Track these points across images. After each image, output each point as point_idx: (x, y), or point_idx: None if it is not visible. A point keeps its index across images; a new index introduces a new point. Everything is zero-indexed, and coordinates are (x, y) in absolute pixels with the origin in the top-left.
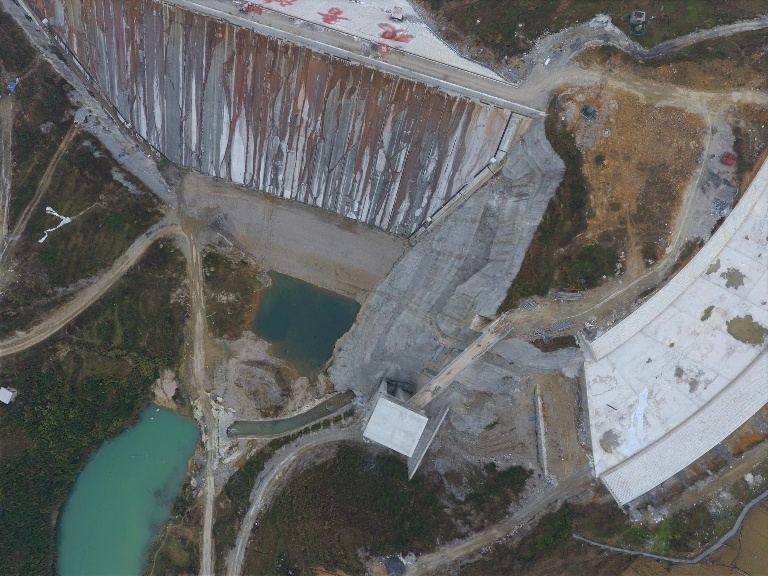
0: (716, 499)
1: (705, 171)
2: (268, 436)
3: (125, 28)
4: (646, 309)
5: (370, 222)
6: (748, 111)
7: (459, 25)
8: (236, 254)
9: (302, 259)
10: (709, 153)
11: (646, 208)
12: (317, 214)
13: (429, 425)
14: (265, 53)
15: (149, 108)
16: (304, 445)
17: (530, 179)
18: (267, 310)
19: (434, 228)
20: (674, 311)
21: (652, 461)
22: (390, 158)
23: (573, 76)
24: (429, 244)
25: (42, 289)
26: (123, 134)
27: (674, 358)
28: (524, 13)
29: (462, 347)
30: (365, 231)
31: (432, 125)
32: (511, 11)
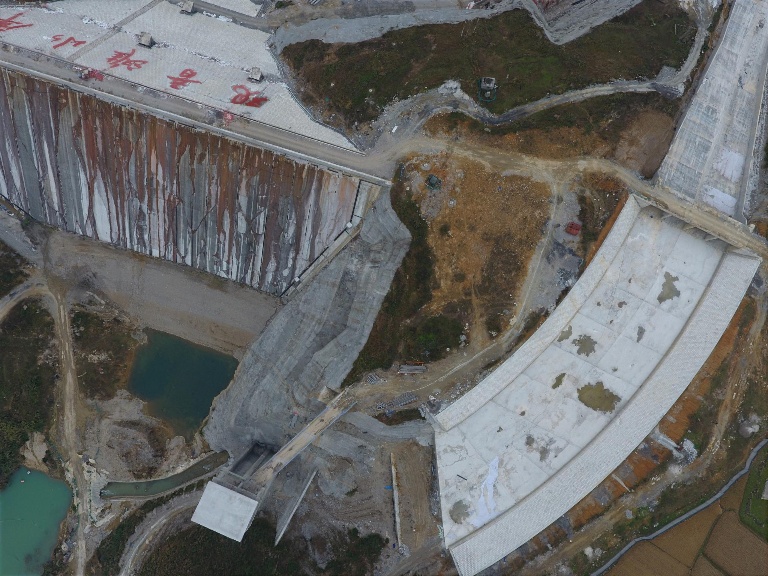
0: (555, 574)
1: (550, 241)
2: (142, 497)
3: None
4: (492, 380)
5: (241, 281)
6: (594, 180)
7: (315, 87)
8: (108, 312)
9: (176, 317)
10: (554, 222)
11: (491, 279)
12: (187, 273)
13: (297, 488)
14: (111, 119)
15: (6, 168)
16: (175, 508)
17: (383, 246)
18: (144, 367)
19: (303, 288)
20: (525, 379)
21: (499, 533)
22: (250, 221)
23: (419, 144)
24: (297, 305)
25: None
26: None
27: (525, 427)
28: (375, 78)
29: (315, 416)
30: (236, 290)
31: (285, 190)
32: (363, 75)
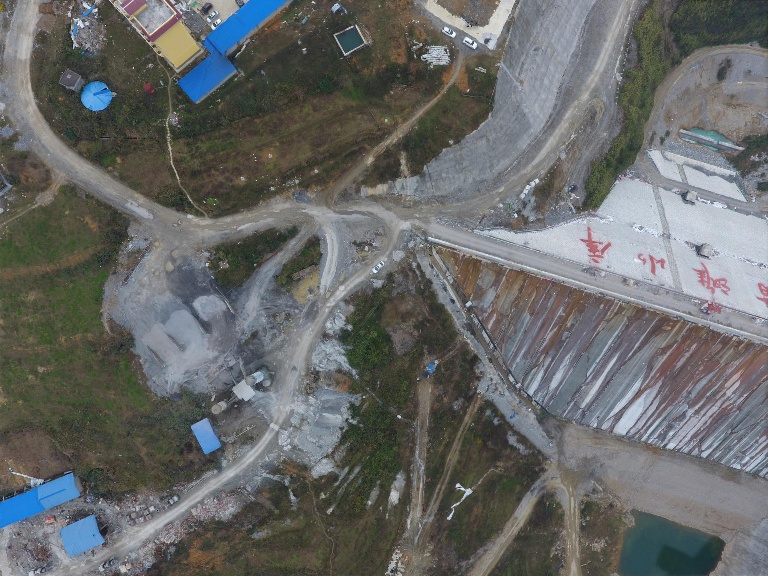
0: None
1: None
2: None
3: (559, 315)
4: None
5: (754, 472)
6: None
7: None
8: (606, 499)
9: (672, 502)
10: None
11: None
12: (701, 465)
13: None
14: (712, 345)
15: (549, 373)
16: None
17: None
18: (628, 549)
19: None
20: None
21: None
22: None
23: None
24: None
25: (452, 567)
26: (510, 392)
27: None
28: None
29: None
30: (749, 481)
31: None
32: None
